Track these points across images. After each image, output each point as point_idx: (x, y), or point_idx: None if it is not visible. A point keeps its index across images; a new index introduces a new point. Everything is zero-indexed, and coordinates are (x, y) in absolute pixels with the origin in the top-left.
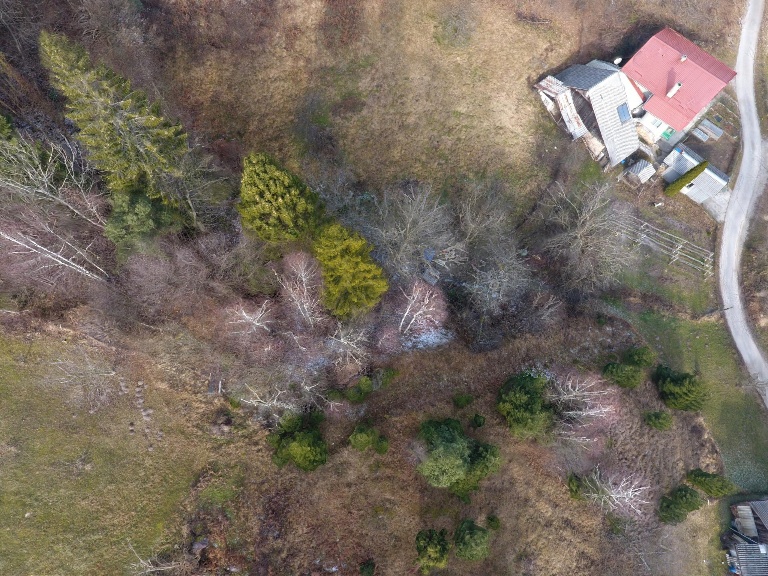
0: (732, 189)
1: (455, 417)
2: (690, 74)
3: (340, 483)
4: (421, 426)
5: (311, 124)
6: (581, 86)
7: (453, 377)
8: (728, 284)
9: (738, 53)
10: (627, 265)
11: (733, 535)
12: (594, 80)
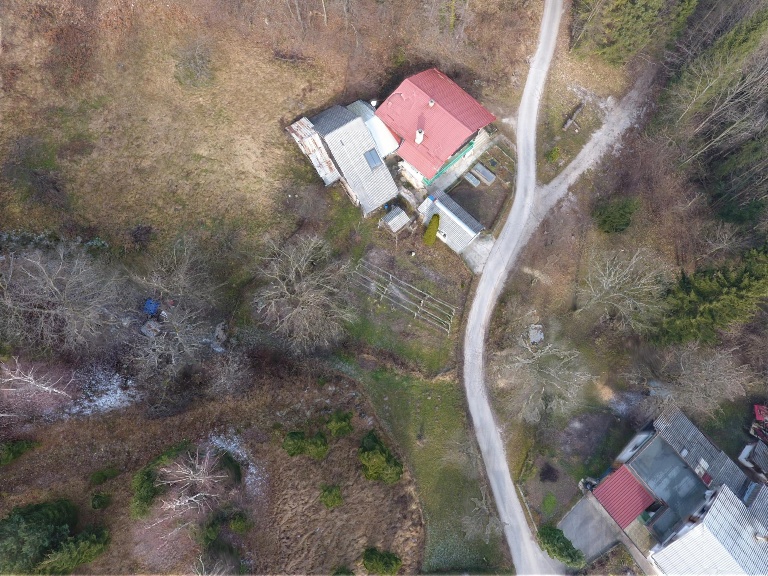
0: (496, 238)
1: (86, 495)
2: (439, 120)
3: None
4: (14, 511)
5: (36, 167)
6: (322, 131)
7: (113, 447)
8: (473, 341)
9: (523, 93)
10: (351, 322)
11: None
12: (336, 125)
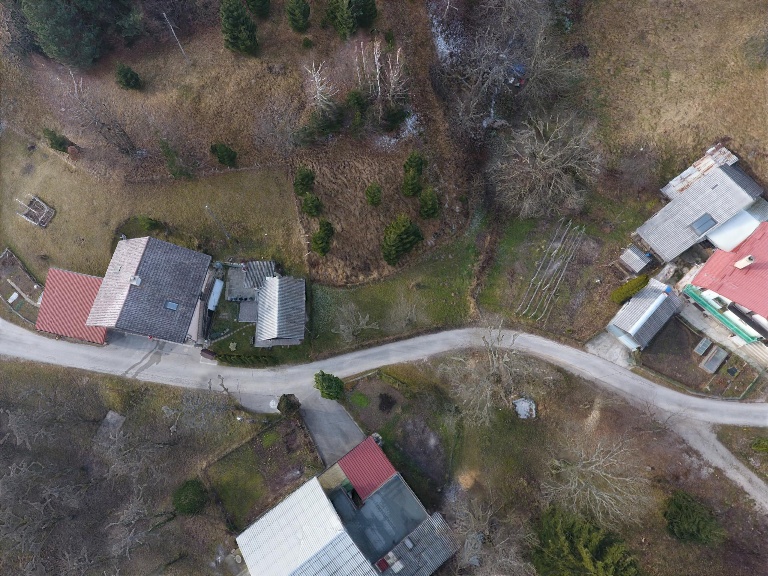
0: (632, 370)
1: None
2: None
3: None
4: None
5: None
6: None
7: (410, 48)
8: None
9: None
10: (520, 215)
11: None
12: None
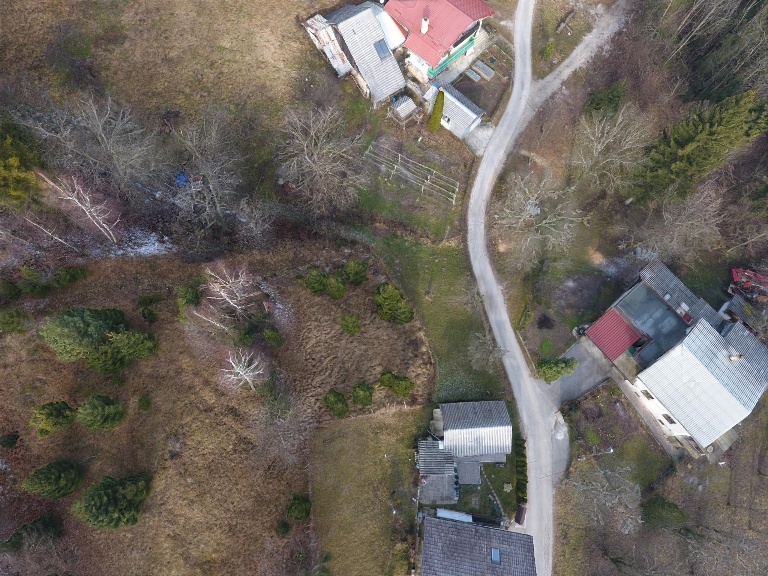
0: (496, 126)
1: (135, 313)
2: (442, 11)
3: None
4: None
5: (73, 55)
6: (336, 21)
7: (155, 282)
8: (476, 213)
9: None
10: (365, 190)
11: (428, 436)
12: (348, 16)
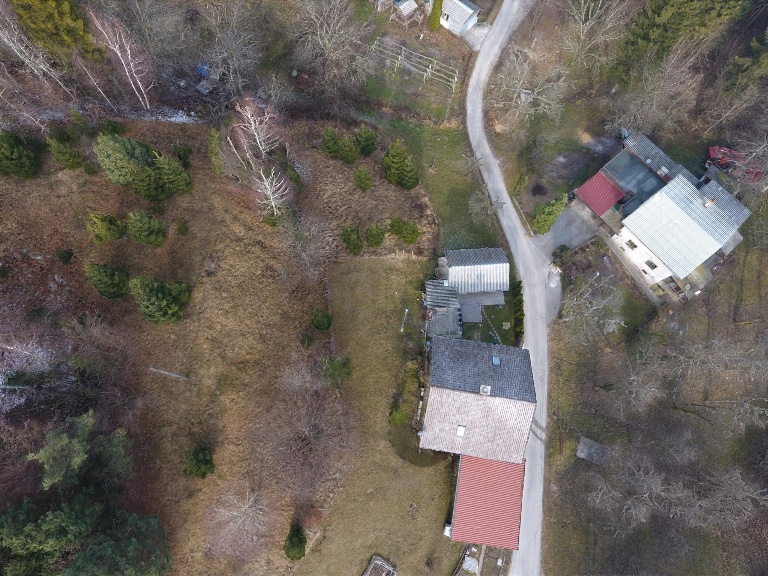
0: (491, 25)
1: None
2: None
3: (51, 195)
4: None
5: None
6: None
7: (186, 142)
8: (474, 99)
9: None
10: (372, 74)
11: None
12: None
